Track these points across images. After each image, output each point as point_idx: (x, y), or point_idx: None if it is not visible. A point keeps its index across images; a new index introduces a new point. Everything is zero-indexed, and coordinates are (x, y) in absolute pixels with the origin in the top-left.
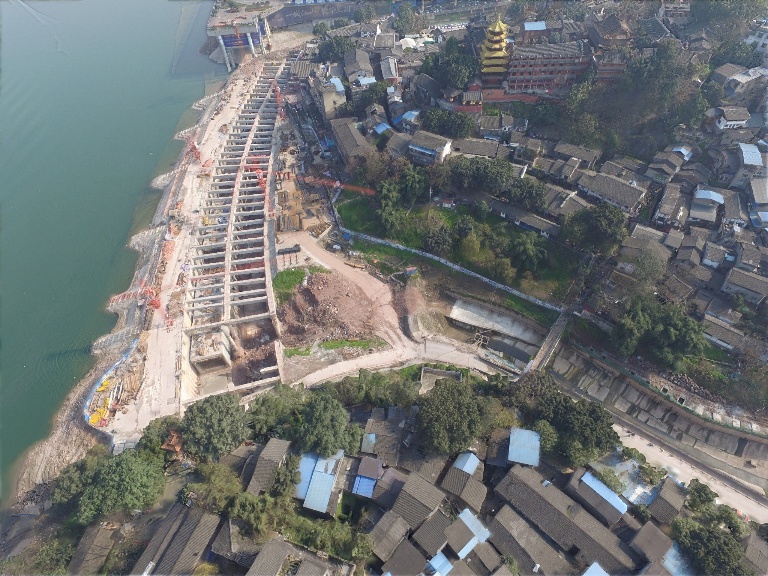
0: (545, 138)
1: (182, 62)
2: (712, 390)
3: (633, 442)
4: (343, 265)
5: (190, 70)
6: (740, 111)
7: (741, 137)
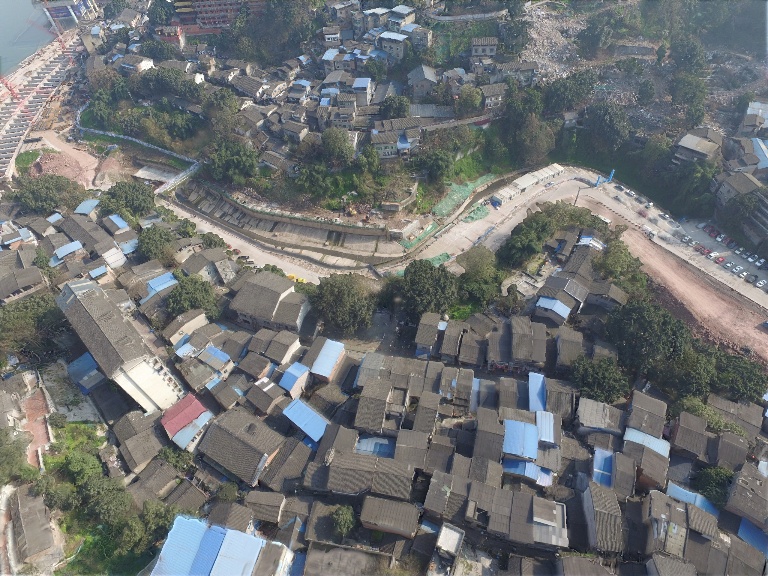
0: (227, 58)
1: (26, 34)
2: (262, 194)
3: (192, 220)
4: (71, 149)
5: (30, 39)
6: (334, 28)
7: (331, 45)
